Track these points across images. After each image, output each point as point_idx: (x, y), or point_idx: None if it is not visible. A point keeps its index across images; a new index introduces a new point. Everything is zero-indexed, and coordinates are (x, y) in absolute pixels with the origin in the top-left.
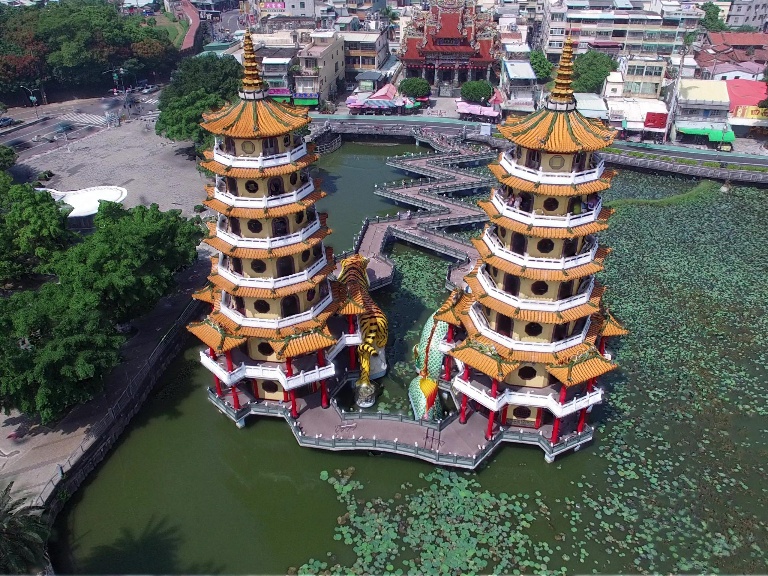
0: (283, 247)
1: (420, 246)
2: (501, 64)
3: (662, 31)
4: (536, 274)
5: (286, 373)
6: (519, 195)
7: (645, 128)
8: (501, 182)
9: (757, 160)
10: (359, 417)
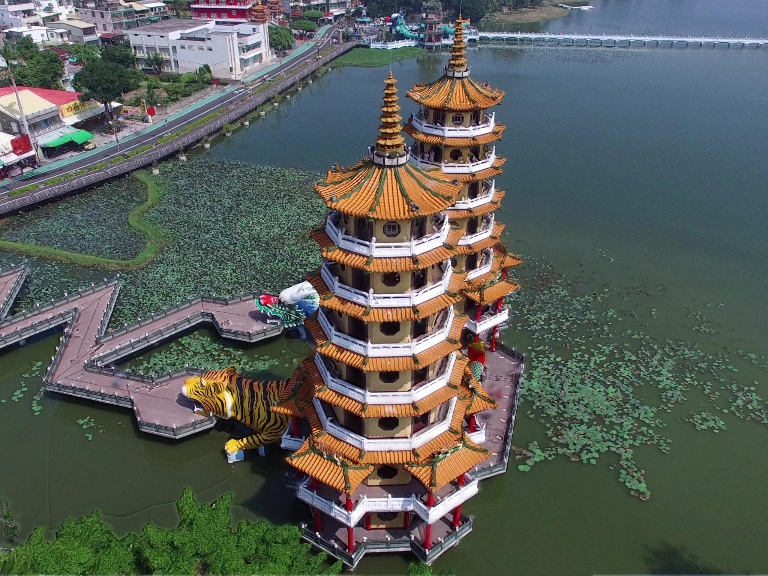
0: None
1: None
2: None
3: None
4: None
5: (471, 432)
6: (471, 152)
7: (19, 157)
8: None
9: (122, 145)
10: None
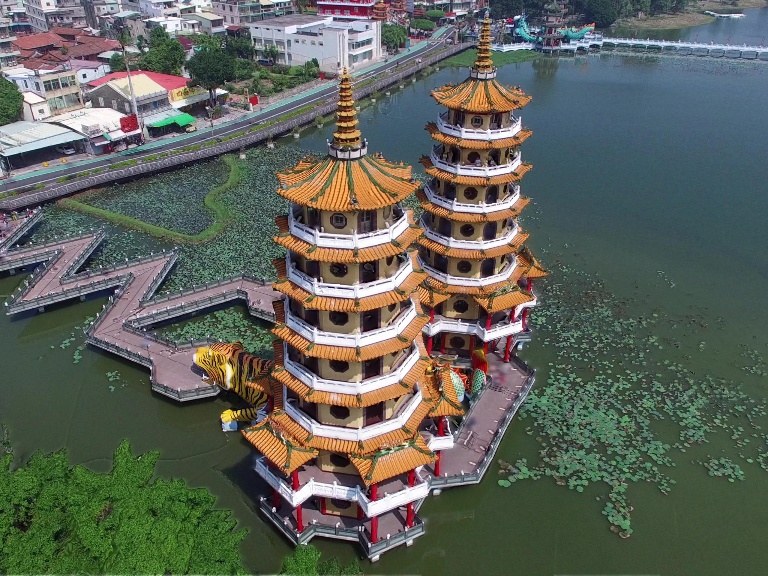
0: None
1: None
2: None
3: None
4: (517, 209)
5: (439, 436)
6: (490, 155)
7: (126, 134)
8: None
9: (220, 129)
10: (463, 426)
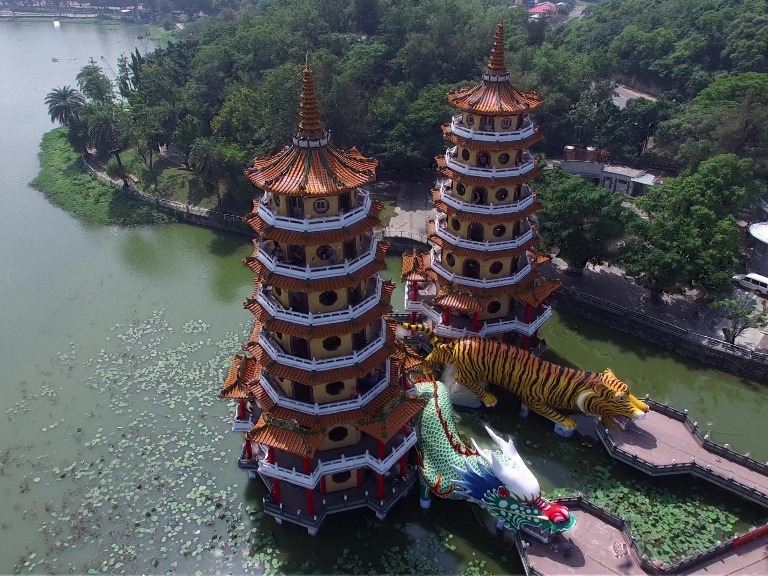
0: None
1: None
2: None
3: None
4: None
5: None
6: None
7: None
8: None
9: None
10: None
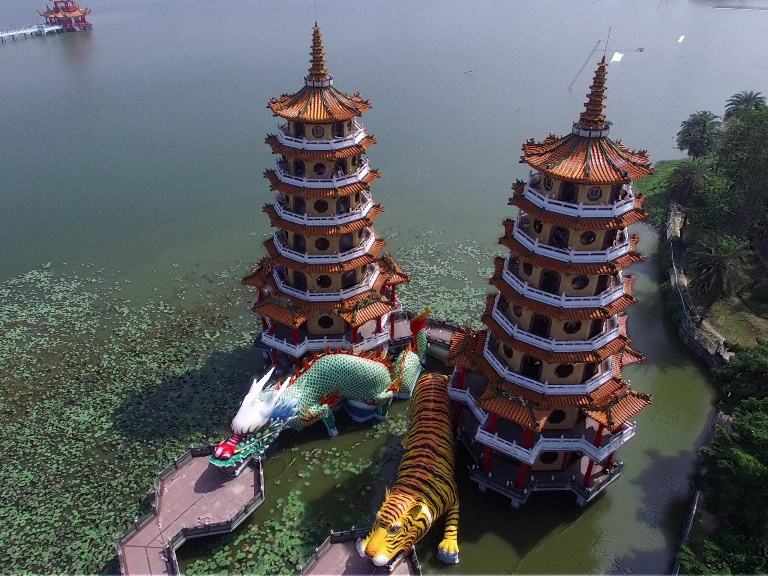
0: None
1: None
2: None
3: None
4: None
5: None
6: None
7: None
8: None
9: None
10: None
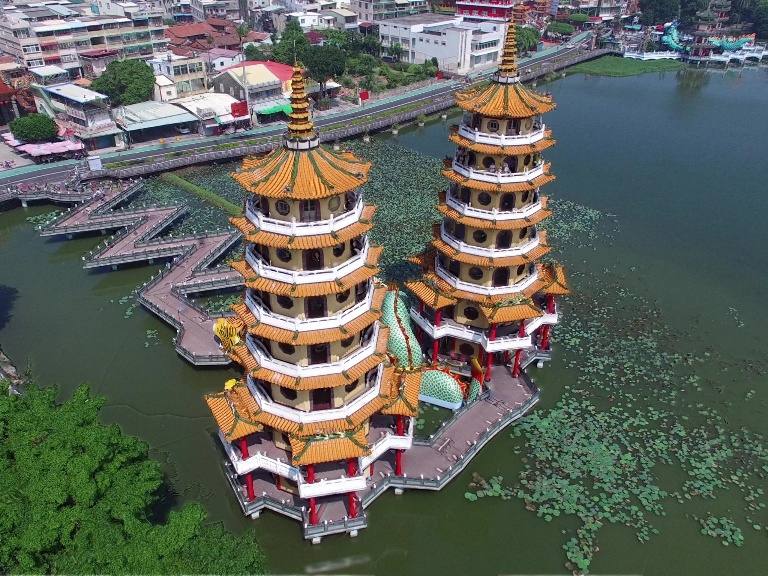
0: (372, 302)
1: (222, 289)
2: (38, 92)
3: (136, 32)
4: (534, 220)
5: (397, 434)
6: (505, 162)
7: (235, 119)
8: (504, 154)
9: (325, 121)
10: (443, 432)
